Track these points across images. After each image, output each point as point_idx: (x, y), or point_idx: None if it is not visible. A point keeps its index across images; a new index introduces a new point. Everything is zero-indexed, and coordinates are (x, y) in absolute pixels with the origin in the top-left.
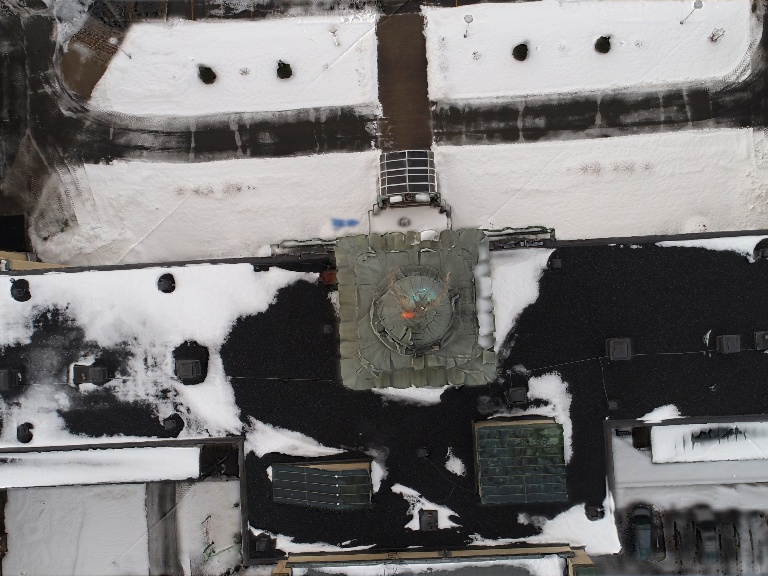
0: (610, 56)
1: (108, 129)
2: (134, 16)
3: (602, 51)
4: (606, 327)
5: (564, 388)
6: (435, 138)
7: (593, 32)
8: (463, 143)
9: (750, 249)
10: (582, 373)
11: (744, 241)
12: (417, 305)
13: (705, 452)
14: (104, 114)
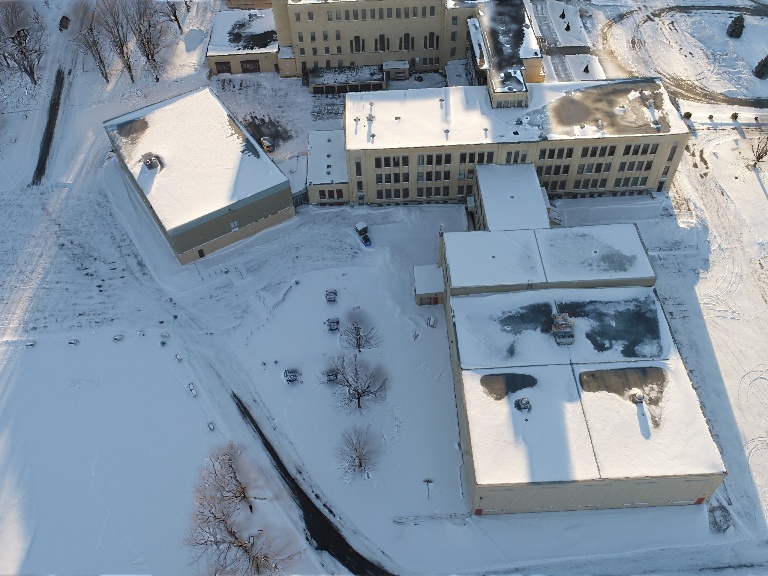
0: None
1: (542, 2)
2: (579, 8)
3: None
4: (502, 6)
5: (486, 1)
6: (553, 56)
7: None
8: (552, 61)
9: None
10: (490, 3)
11: None
12: None
13: (472, 25)
14: (546, 1)
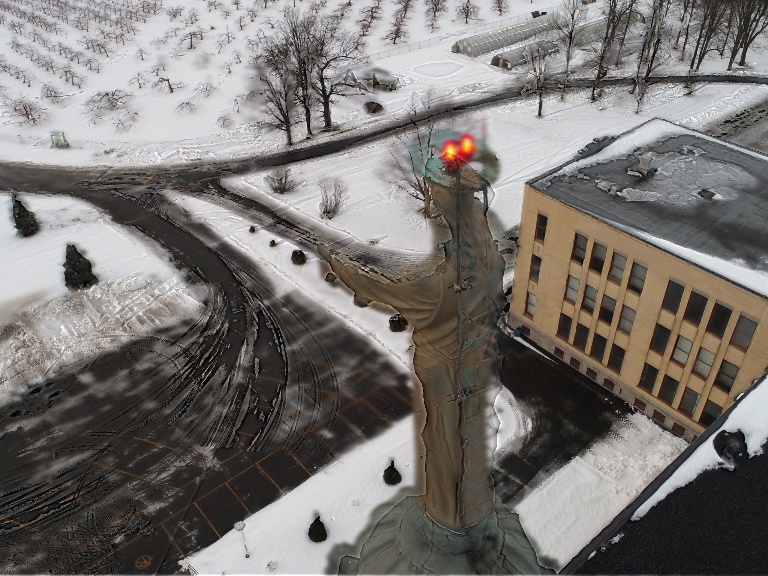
0: (406, 481)
1: None
2: None
3: (395, 482)
4: None
5: None
6: None
7: (374, 473)
8: None
9: (715, 458)
10: None
11: (701, 455)
12: (457, 195)
13: None
14: None
